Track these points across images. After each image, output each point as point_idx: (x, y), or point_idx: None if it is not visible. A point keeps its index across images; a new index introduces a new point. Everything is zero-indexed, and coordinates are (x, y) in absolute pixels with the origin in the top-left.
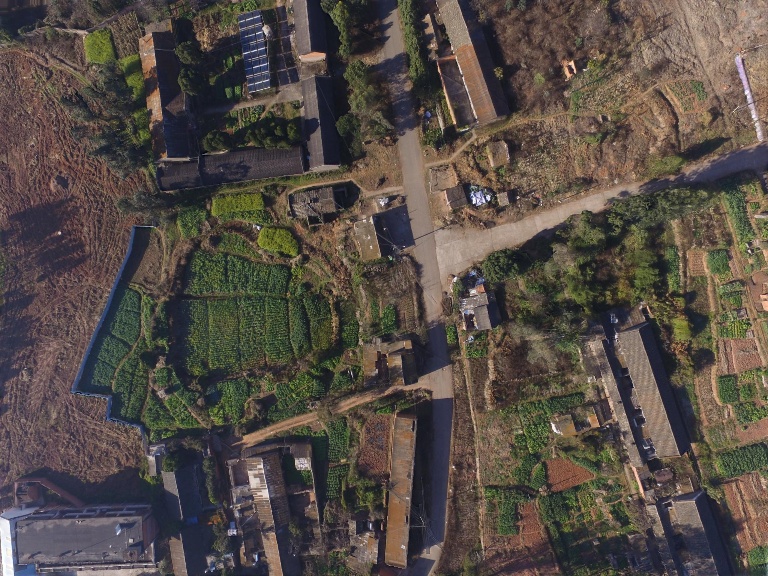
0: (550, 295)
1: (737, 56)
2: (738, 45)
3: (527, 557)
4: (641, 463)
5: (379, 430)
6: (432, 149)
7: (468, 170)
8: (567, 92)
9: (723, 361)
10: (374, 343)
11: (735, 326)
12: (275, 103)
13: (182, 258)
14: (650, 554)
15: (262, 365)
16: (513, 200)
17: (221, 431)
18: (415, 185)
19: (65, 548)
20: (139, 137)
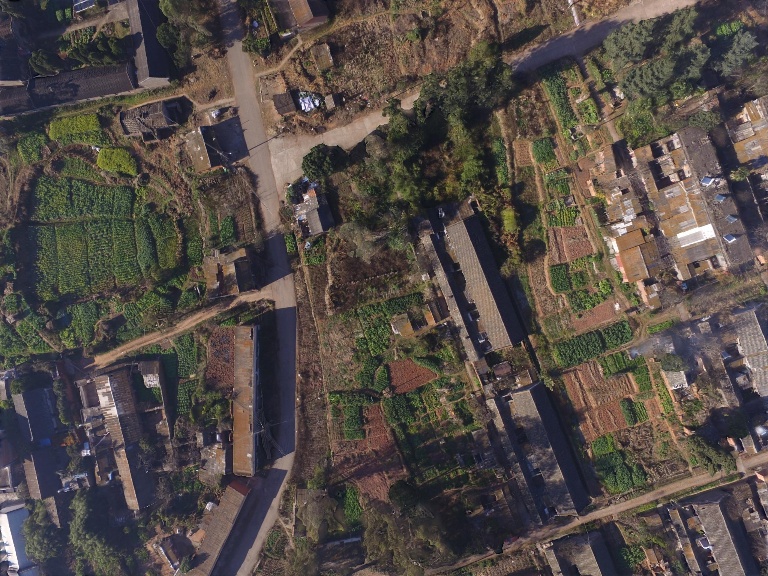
0: (383, 196)
1: None
2: None
3: (375, 461)
4: (476, 357)
5: (224, 343)
6: (260, 58)
7: (295, 76)
8: None
9: (554, 250)
10: (212, 255)
11: (564, 214)
12: (105, 23)
13: (25, 184)
14: None
15: (111, 287)
16: (340, 103)
17: (71, 354)
18: (246, 96)
19: None
20: None
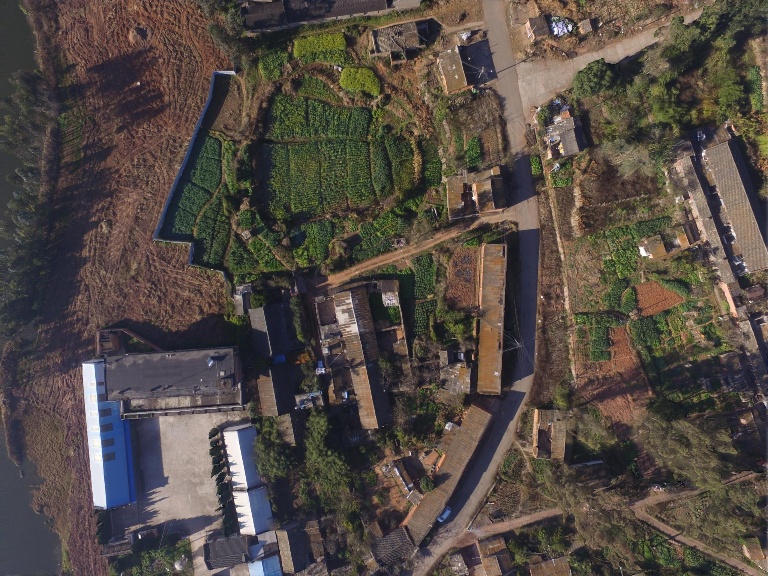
0: (634, 121)
1: None
2: None
3: (619, 383)
4: (733, 278)
5: (466, 263)
6: None
7: (549, 1)
8: None
9: None
10: (460, 174)
11: None
12: None
13: (264, 102)
14: (744, 372)
15: (345, 207)
16: (595, 28)
17: (306, 271)
18: (496, 20)
19: (155, 383)
20: None
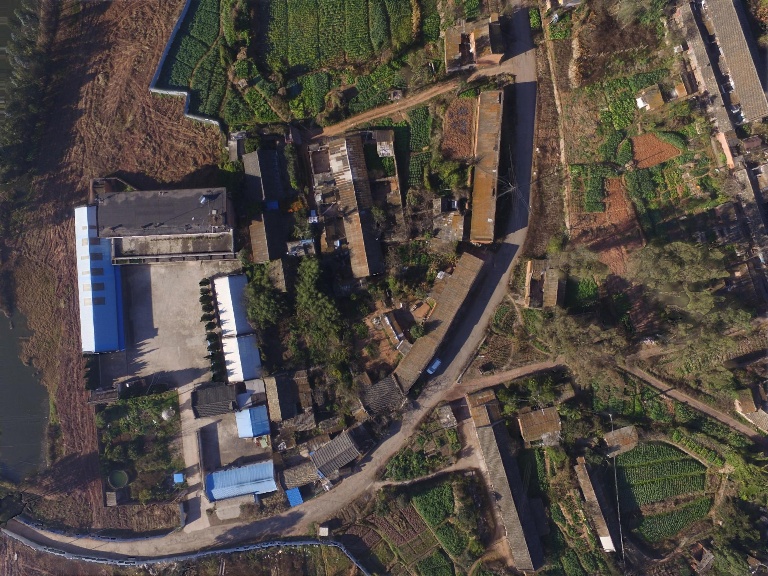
0: None
1: None
2: None
3: (613, 235)
4: (730, 126)
5: (462, 114)
6: None
7: None
8: None
9: None
10: (458, 24)
11: None
12: None
13: None
14: (739, 224)
15: (342, 62)
16: None
17: (302, 122)
18: None
19: (147, 221)
20: None
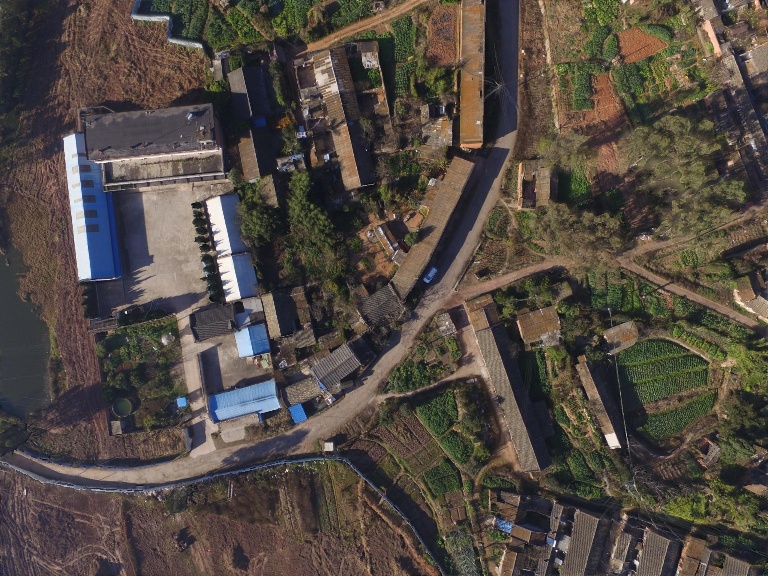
0: None
1: None
2: None
3: (604, 132)
4: (716, 12)
5: (446, 21)
6: None
7: None
8: None
9: None
10: None
11: None
12: None
13: None
14: (729, 111)
15: None
16: None
17: (285, 38)
18: None
19: (135, 141)
20: None
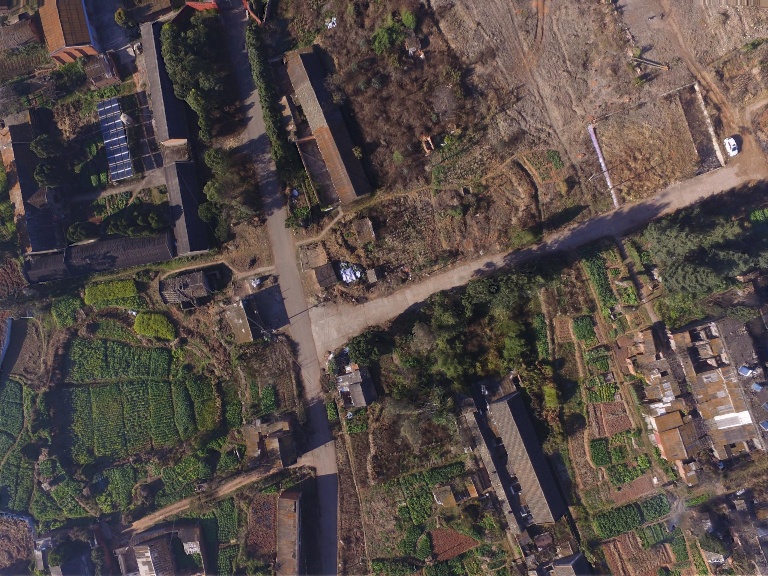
0: (424, 367)
1: (589, 125)
2: (590, 114)
3: None
4: (519, 530)
5: (266, 510)
6: (301, 228)
7: (336, 248)
8: (428, 167)
9: (594, 425)
10: (254, 425)
11: (603, 390)
12: (142, 189)
13: (60, 348)
14: None
15: (148, 449)
16: (382, 276)
17: (109, 519)
18: (286, 264)
19: None
20: (7, 229)
